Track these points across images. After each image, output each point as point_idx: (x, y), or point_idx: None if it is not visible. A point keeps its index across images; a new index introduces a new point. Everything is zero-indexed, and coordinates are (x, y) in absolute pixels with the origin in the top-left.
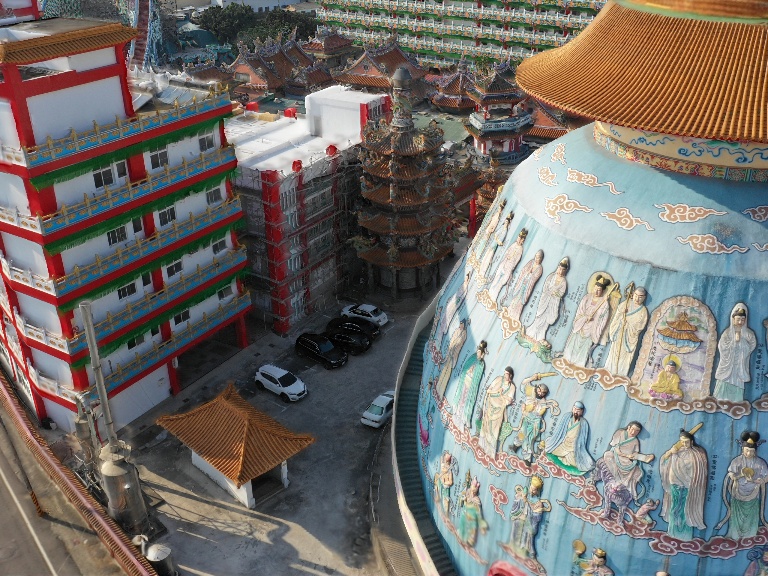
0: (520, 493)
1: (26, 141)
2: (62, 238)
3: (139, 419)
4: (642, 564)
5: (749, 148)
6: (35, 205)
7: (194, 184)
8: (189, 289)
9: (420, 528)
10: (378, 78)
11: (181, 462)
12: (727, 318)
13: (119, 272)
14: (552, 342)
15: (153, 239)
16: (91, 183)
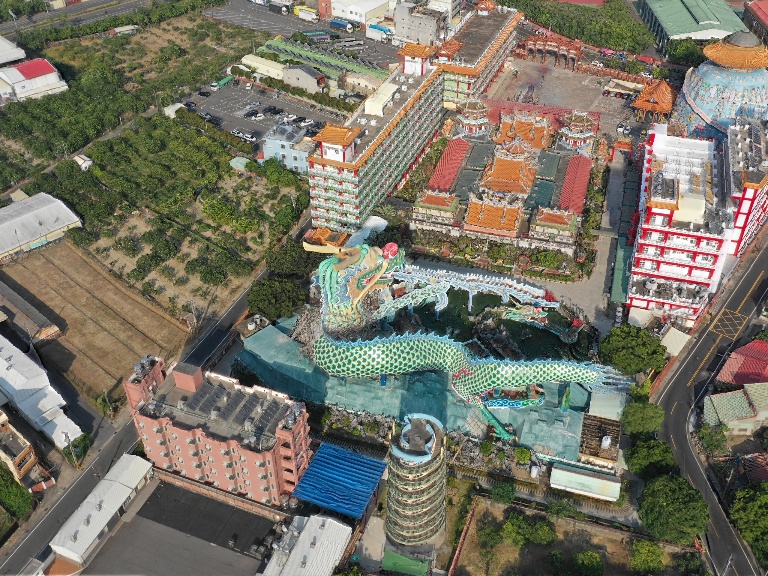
0: None
1: None
2: None
3: None
4: None
5: None
6: None
7: None
8: None
9: None
10: (525, 166)
11: None
12: None
13: None
14: None
15: None
16: None
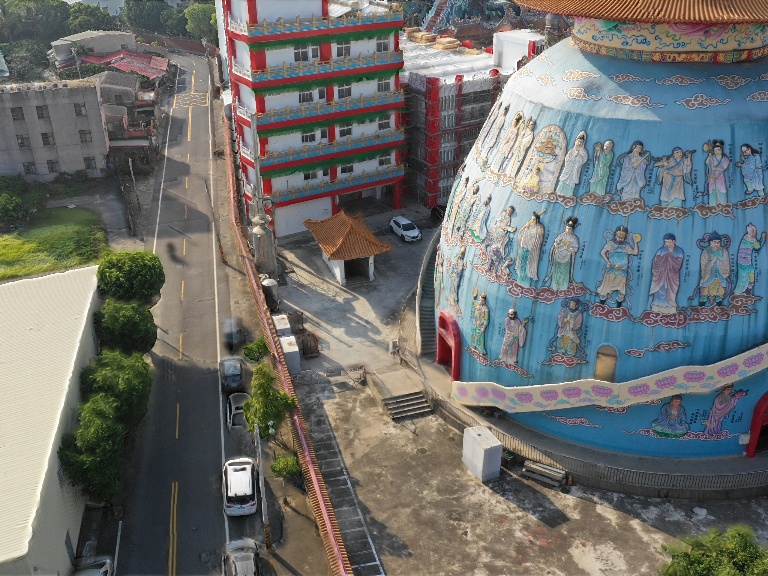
0: (456, 258)
1: (252, 21)
2: (265, 87)
3: (305, 232)
4: (503, 303)
5: (629, 35)
6: (254, 64)
7: (366, 73)
8: (353, 148)
9: (424, 301)
10: None
11: (317, 257)
12: (574, 141)
13: (301, 120)
14: (489, 158)
15: (329, 104)
16: (292, 57)
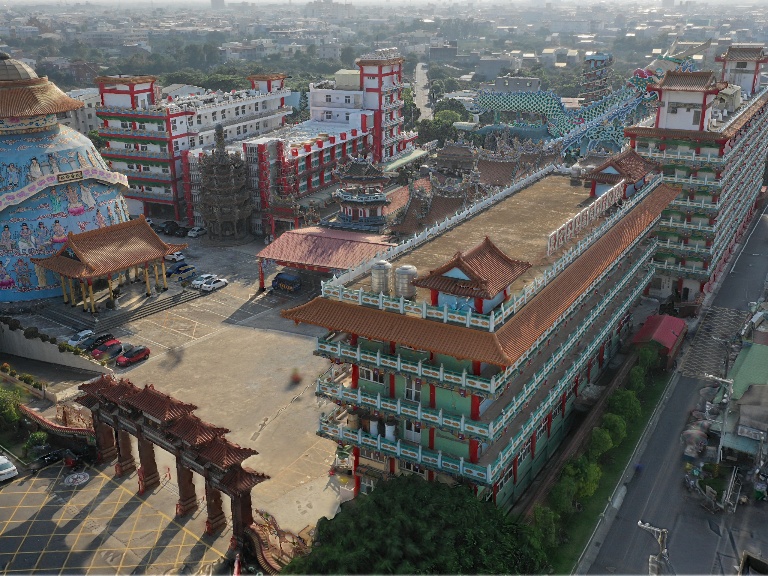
0: None
1: None
2: None
3: None
4: None
5: None
6: None
7: (149, 140)
8: None
9: None
10: None
11: None
12: None
13: (120, 156)
14: None
15: None
16: (120, 125)
